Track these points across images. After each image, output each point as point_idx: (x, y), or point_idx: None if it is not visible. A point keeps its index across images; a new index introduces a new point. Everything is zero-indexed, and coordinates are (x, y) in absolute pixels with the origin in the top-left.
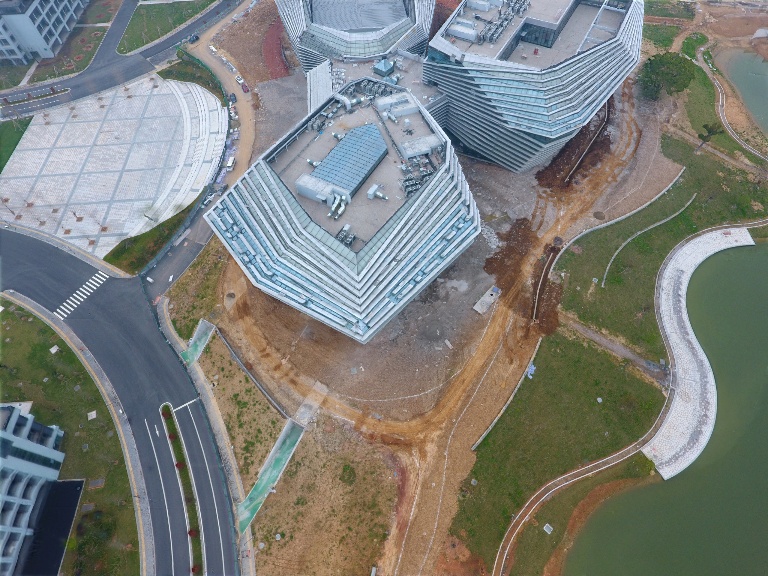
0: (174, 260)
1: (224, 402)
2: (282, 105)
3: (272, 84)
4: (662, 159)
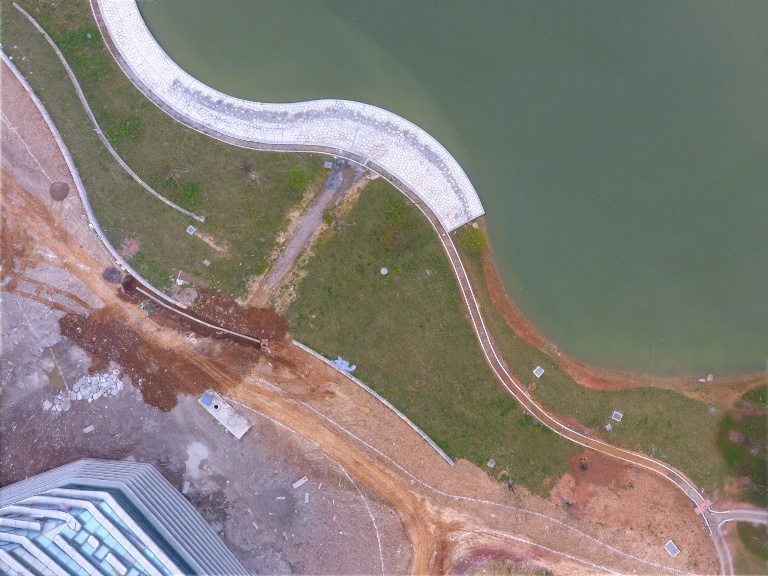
0: None
1: None
2: None
3: None
4: None
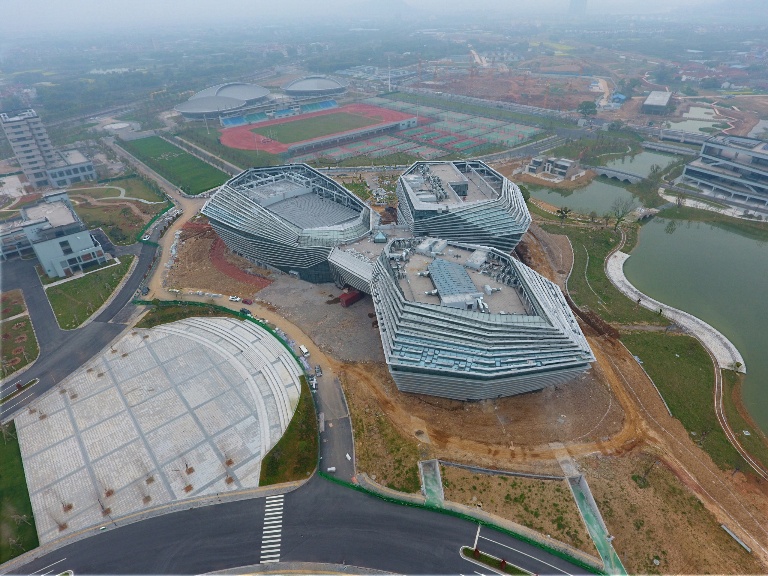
0: (334, 443)
1: (503, 510)
2: (294, 300)
3: (267, 291)
4: (553, 235)
